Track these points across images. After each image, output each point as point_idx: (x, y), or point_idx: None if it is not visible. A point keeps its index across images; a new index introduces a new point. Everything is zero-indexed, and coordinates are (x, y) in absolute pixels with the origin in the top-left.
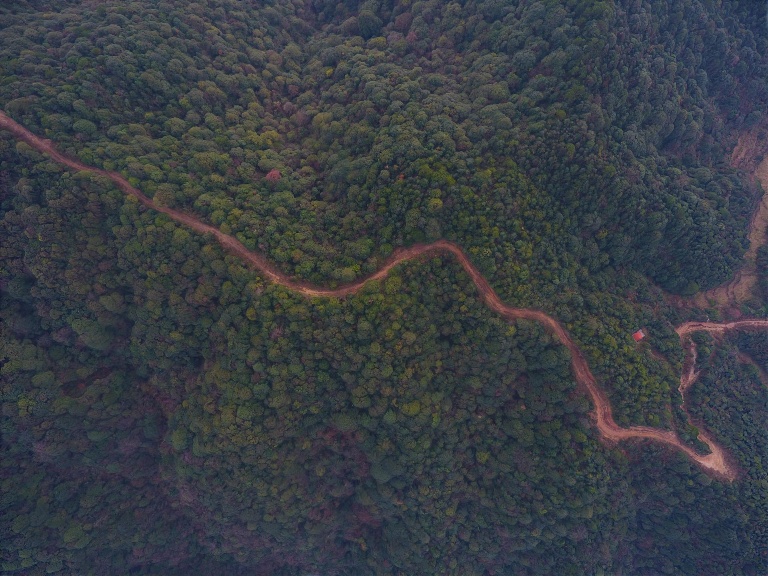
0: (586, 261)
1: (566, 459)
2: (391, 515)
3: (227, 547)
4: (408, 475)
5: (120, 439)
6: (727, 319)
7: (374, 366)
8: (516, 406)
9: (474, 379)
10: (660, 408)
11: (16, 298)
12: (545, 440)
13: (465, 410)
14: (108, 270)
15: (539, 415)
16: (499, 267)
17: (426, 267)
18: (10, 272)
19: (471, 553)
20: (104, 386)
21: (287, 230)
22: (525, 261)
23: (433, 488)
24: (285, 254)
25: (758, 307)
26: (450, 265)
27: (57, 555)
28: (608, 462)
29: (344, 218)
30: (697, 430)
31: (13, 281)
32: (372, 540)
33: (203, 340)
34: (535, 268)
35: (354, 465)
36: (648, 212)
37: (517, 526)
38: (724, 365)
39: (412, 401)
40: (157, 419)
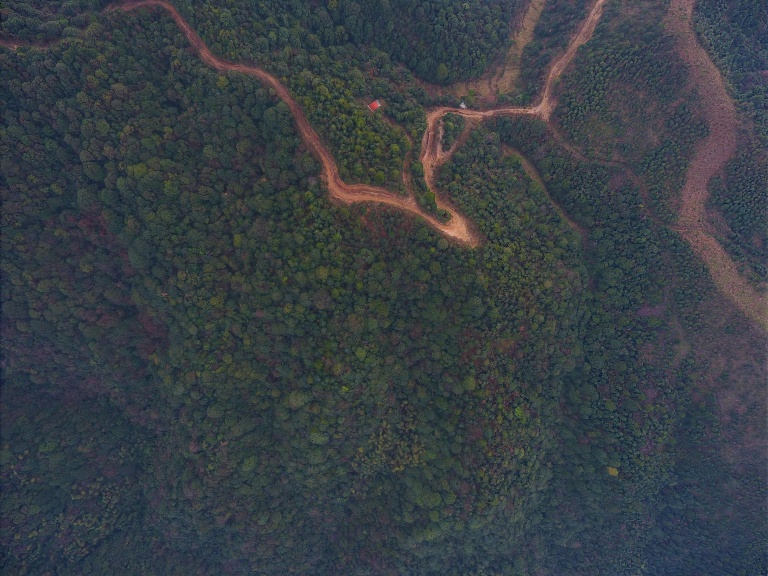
0: (317, 30)
1: (296, 219)
2: (165, 314)
3: (13, 361)
4: (159, 255)
5: None
6: (484, 105)
7: (88, 121)
8: (258, 180)
9: (207, 147)
10: (390, 168)
11: None
12: (280, 205)
13: (211, 188)
14: None
15: (276, 184)
16: (197, 9)
17: (131, 17)
18: None
19: (247, 349)
20: None
21: None
22: (229, 8)
23: (190, 272)
24: None
25: (516, 94)
26: (161, 19)
27: None
28: (341, 223)
29: None
30: (432, 193)
31: None
32: (160, 350)
33: None
34: (244, 19)
35: (122, 262)
36: None
37: (273, 306)
38: (479, 148)
39: (137, 163)
40: None
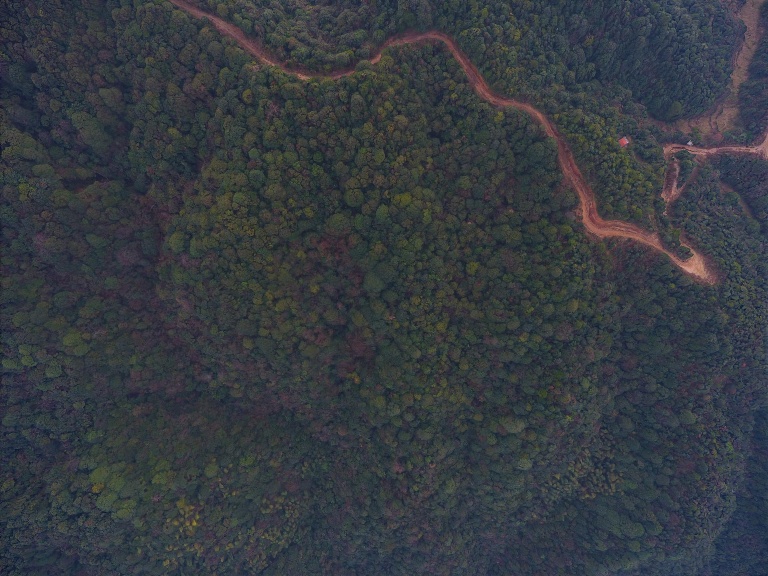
0: (573, 66)
1: (552, 252)
2: (383, 336)
3: (223, 375)
4: (400, 281)
5: (118, 248)
6: (709, 143)
7: (367, 150)
8: (505, 210)
9: (464, 178)
10: (643, 205)
11: (17, 92)
12: (532, 237)
13: (455, 217)
14: (107, 61)
15: (527, 216)
16: (488, 47)
17: (417, 51)
18: (11, 58)
19: (461, 374)
20: (103, 189)
21: (283, 20)
22: (513, 46)
23: (424, 298)
24: (281, 38)
25: (739, 133)
26: (441, 54)
27: (56, 358)
28: (593, 258)
29: (338, 16)
30: (679, 231)
31: (14, 65)
32: (365, 370)
33: (200, 140)
34: (523, 56)
35: (347, 284)
36: (633, 18)
37: (505, 334)
38: (706, 185)
39: (404, 192)
40: (155, 234)
